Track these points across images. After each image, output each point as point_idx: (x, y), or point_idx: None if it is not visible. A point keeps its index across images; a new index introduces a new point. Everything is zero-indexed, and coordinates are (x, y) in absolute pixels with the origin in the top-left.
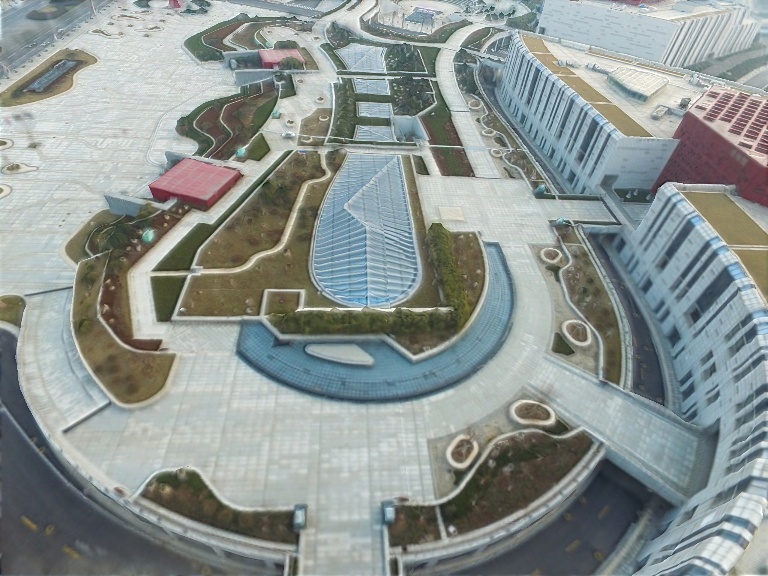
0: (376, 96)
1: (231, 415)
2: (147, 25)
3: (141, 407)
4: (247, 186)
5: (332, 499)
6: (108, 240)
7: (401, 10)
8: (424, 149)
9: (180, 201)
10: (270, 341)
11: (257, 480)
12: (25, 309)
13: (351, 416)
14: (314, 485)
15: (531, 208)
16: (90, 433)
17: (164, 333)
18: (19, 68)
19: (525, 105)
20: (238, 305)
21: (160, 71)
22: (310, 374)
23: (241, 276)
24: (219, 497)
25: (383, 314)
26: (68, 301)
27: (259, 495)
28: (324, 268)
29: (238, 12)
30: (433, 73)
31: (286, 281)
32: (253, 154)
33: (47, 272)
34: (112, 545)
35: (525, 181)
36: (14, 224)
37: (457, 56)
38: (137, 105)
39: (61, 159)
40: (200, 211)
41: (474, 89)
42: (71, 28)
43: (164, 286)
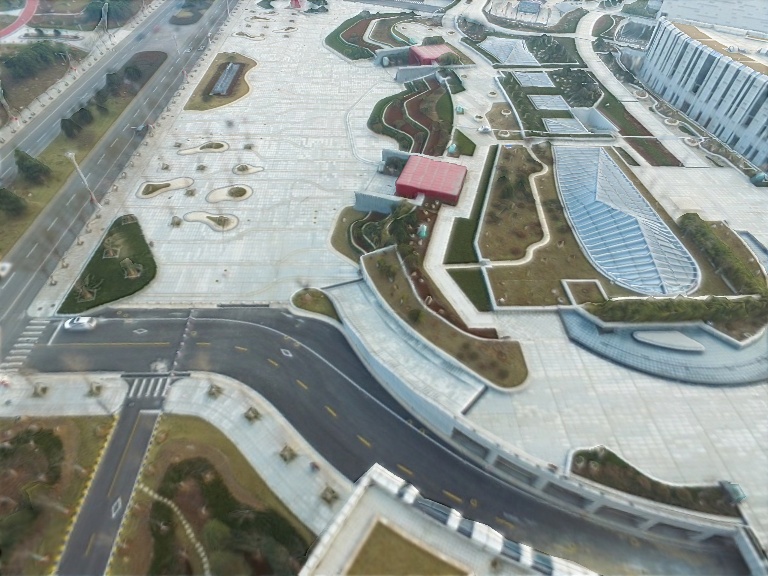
0: (543, 89)
1: (603, 398)
2: (281, 26)
3: (518, 391)
4: (477, 181)
5: (745, 476)
6: (395, 235)
7: (506, 1)
8: (619, 140)
9: (428, 197)
10: (594, 329)
11: (665, 458)
12: (336, 301)
13: (714, 399)
14: (720, 463)
15: (758, 196)
16: (487, 415)
17: (493, 322)
18: (192, 72)
19: (690, 93)
20: (545, 295)
21: (319, 71)
22: (651, 360)
23: (530, 267)
24: (645, 474)
25: (701, 302)
26: (368, 293)
27: (676, 472)
28: (604, 259)
29: (355, 9)
30: (584, 64)
31: (574, 272)
32: (463, 149)
33: (328, 267)
34: (538, 518)
35: (736, 169)
36: (273, 222)
37: (598, 45)
38: (318, 105)
39: (279, 159)
40: (450, 206)
41: (633, 78)
42: (216, 32)
43: (466, 278)
